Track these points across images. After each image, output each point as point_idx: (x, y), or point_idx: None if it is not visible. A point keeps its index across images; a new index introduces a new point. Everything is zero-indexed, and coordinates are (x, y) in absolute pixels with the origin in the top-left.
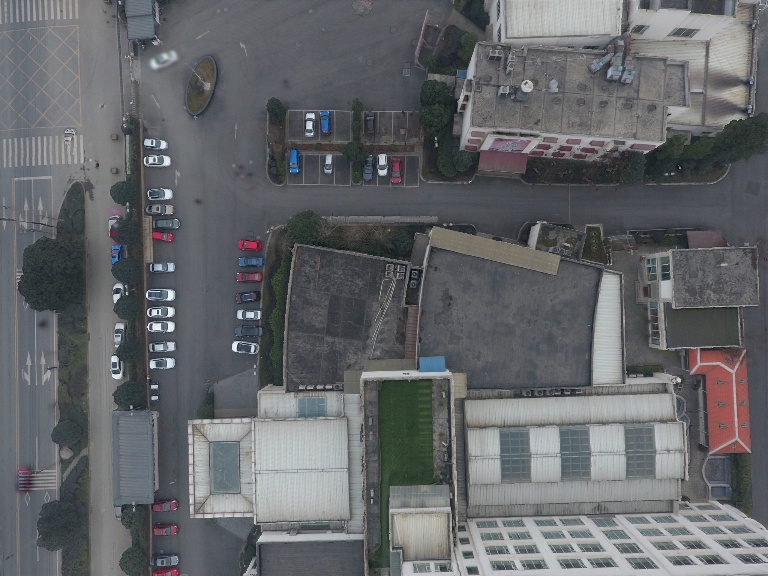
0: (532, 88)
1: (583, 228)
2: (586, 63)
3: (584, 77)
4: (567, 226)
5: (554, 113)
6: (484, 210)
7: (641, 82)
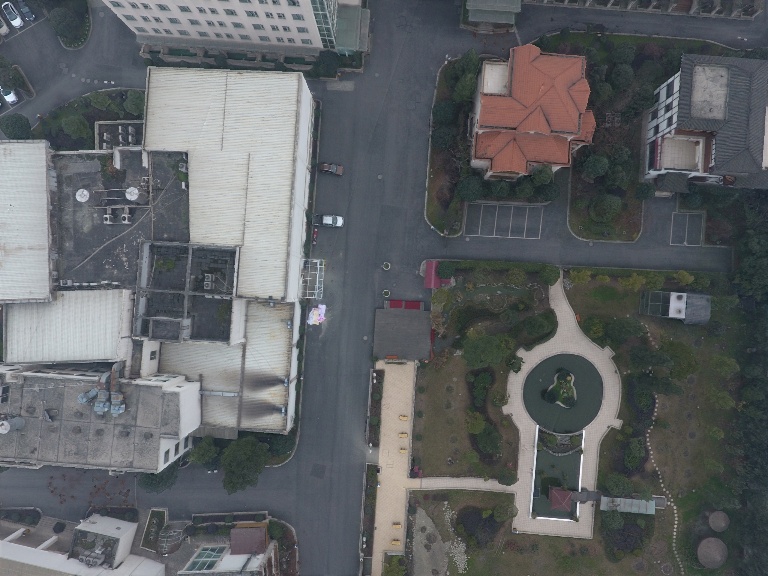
0: (8, 429)
1: (148, 512)
2: (84, 390)
3: (81, 404)
4: (126, 514)
5: (51, 441)
6: (50, 493)
7: (139, 409)
